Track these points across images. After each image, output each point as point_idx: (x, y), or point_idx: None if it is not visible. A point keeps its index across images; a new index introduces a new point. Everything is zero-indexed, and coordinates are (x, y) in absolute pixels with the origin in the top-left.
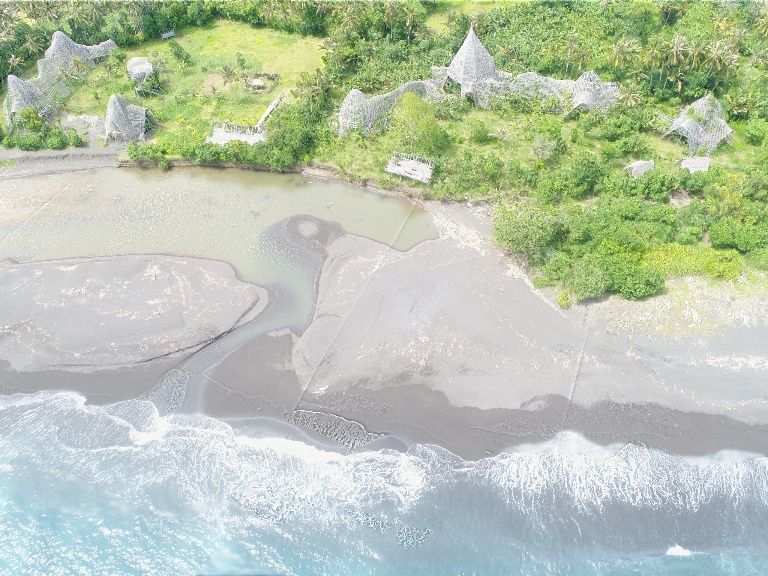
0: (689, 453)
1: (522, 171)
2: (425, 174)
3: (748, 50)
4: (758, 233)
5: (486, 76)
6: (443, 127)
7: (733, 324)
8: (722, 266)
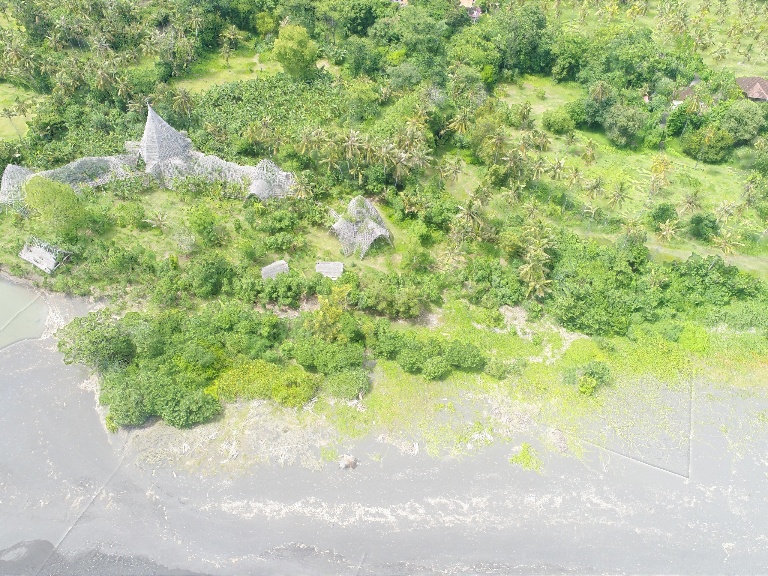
0: None
1: (153, 266)
2: (49, 264)
3: (460, 143)
4: (338, 355)
5: (173, 156)
6: (116, 208)
7: (268, 461)
8: (285, 392)
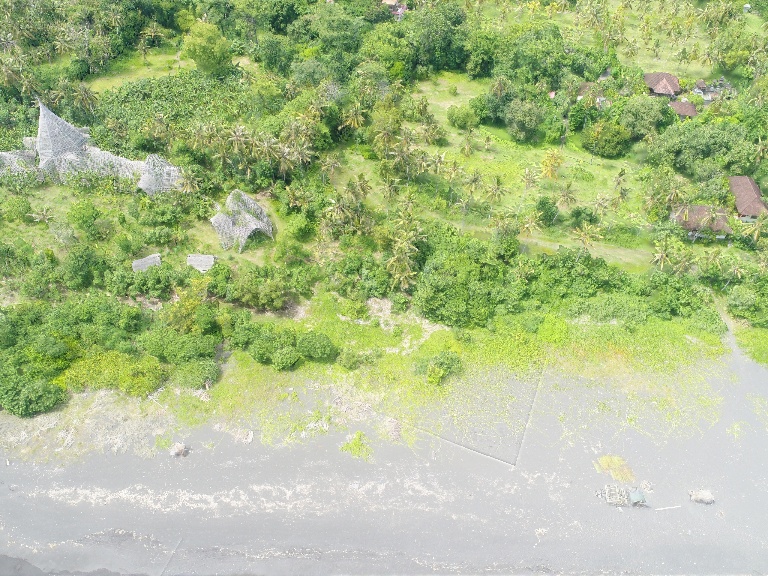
0: None
1: (27, 259)
2: None
3: (360, 138)
4: None
5: (68, 151)
6: None
7: (102, 449)
8: (129, 382)
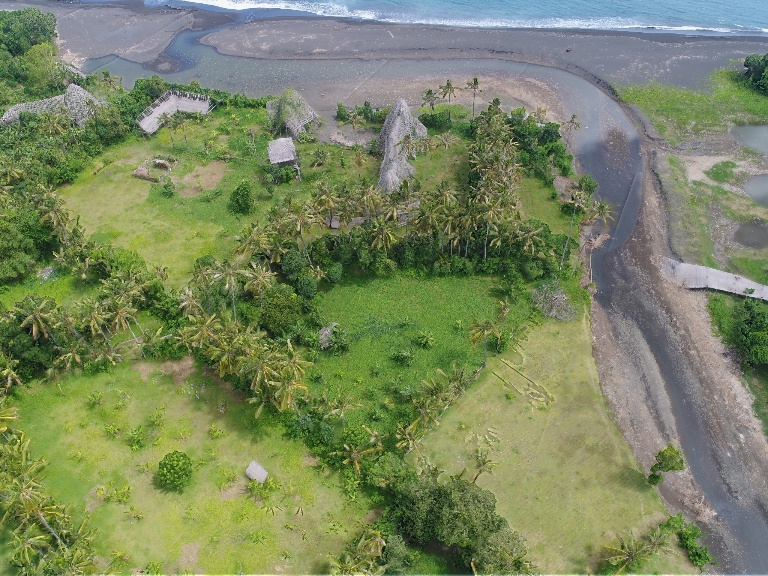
0: (53, 0)
1: None
2: None
3: None
4: None
5: None
6: None
7: None
8: None
